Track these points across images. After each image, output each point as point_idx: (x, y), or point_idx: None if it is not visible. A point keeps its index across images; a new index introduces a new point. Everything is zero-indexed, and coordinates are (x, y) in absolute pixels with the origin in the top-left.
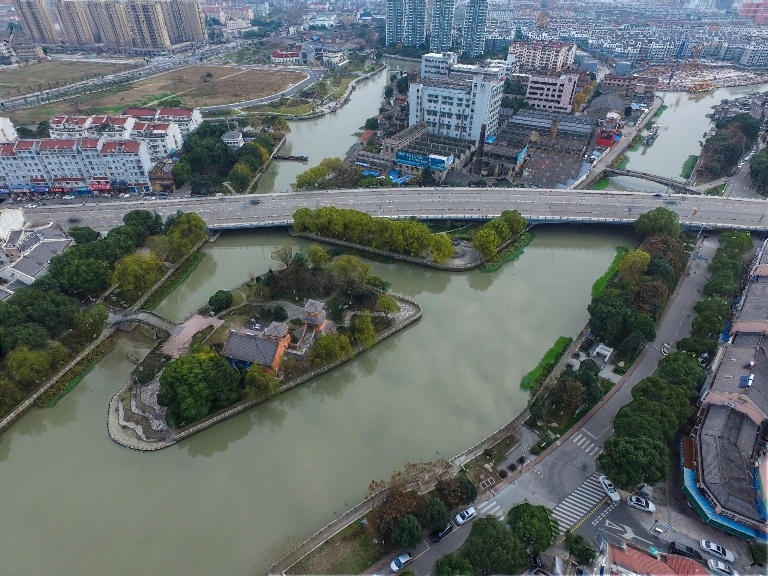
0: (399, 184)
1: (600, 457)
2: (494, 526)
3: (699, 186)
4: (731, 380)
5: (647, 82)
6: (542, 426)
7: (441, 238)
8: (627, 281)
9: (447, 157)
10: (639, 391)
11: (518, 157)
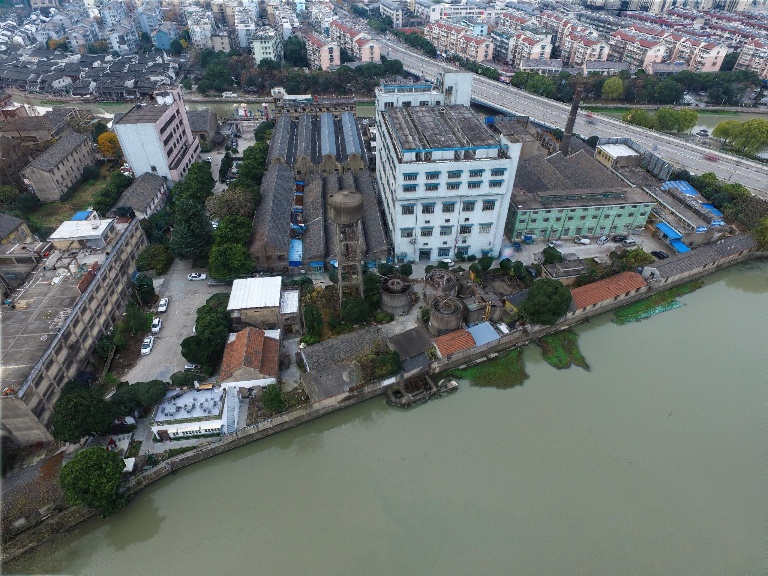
0: (687, 179)
1: (760, 81)
2: None
3: None
4: (679, 67)
5: (3, 102)
6: None
7: (732, 122)
8: (651, 80)
9: (603, 147)
10: (714, 81)
11: (528, 119)
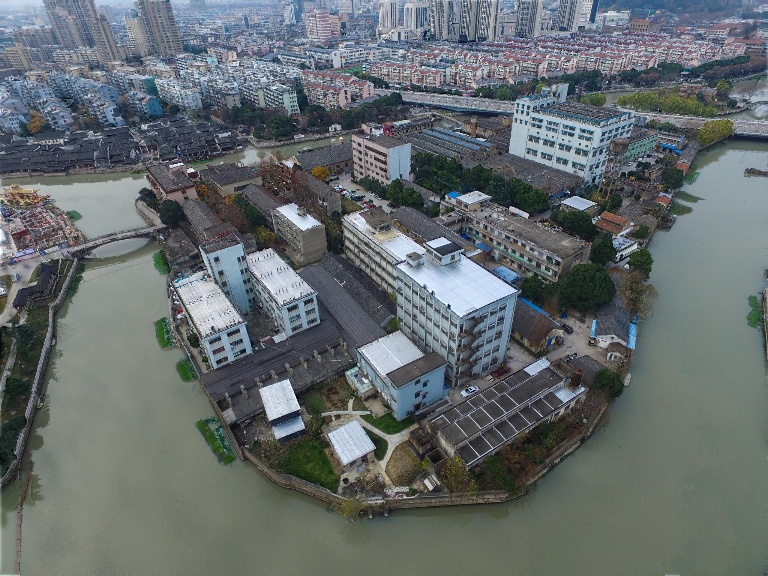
0: (641, 126)
1: None
2: (634, 70)
3: (425, 114)
4: (560, 73)
5: None
6: (606, 88)
7: None
8: None
9: None
10: (582, 78)
11: None
